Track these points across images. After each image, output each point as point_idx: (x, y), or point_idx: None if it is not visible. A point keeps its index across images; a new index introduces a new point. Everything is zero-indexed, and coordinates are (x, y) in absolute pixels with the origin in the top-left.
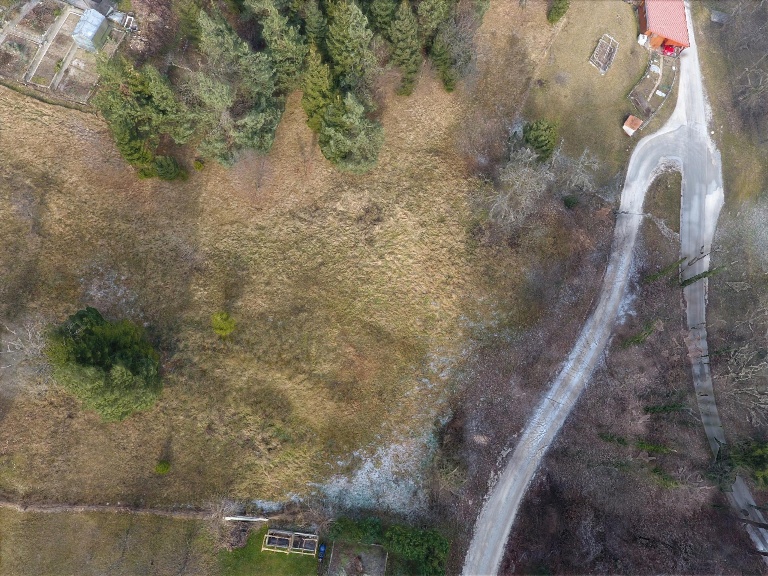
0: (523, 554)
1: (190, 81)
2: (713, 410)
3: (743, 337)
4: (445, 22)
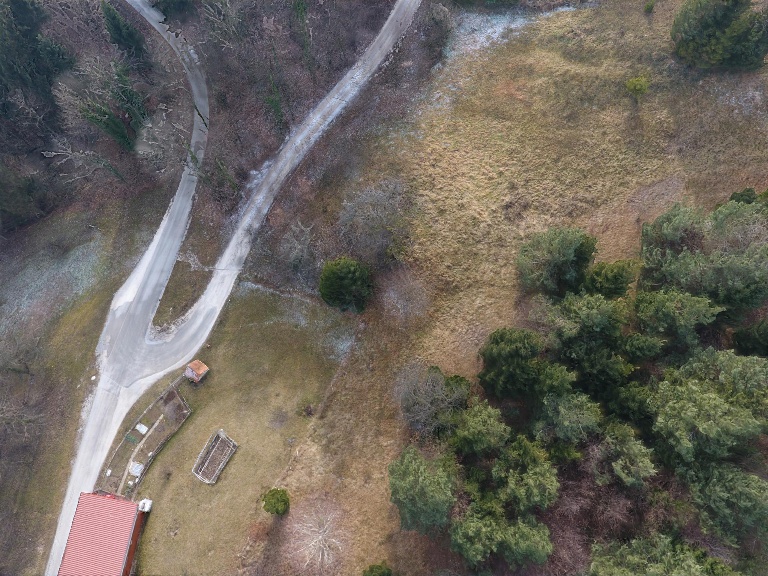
0: (381, 6)
1: (765, 230)
2: (197, 123)
3: (147, 177)
4: (455, 426)
